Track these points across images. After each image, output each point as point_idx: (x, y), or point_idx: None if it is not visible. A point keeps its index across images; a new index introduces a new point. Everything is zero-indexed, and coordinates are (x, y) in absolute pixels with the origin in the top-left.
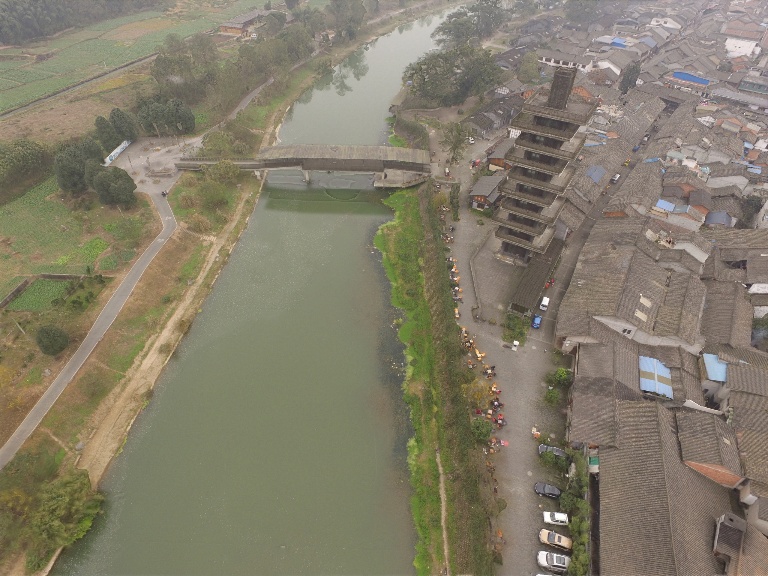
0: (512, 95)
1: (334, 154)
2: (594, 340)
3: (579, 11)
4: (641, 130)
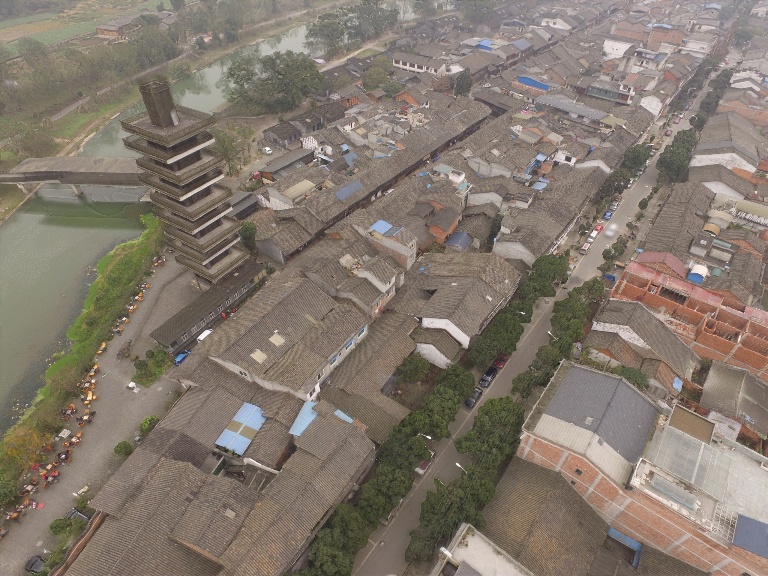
0: (338, 102)
1: (92, 167)
2: None
3: (474, 11)
4: (440, 140)
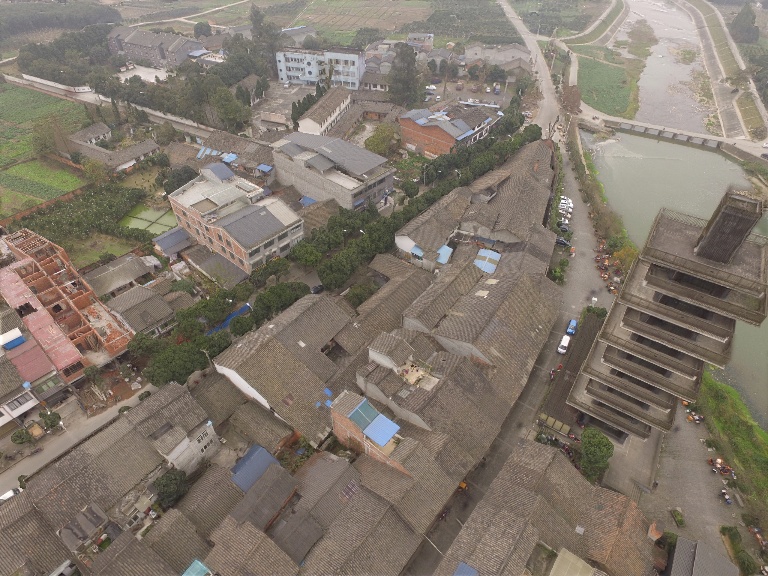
0: None
1: None
2: None
3: None
4: None
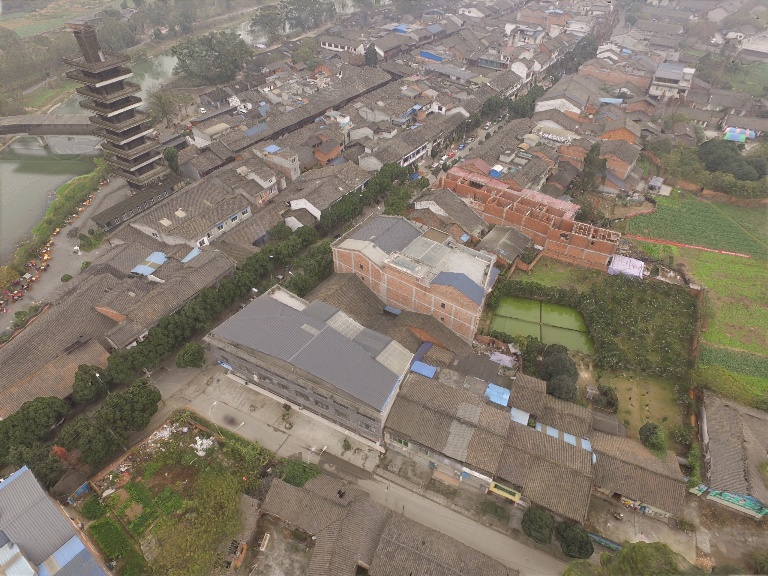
0: None
1: (54, 121)
2: (122, 241)
3: (402, 4)
4: (341, 98)
